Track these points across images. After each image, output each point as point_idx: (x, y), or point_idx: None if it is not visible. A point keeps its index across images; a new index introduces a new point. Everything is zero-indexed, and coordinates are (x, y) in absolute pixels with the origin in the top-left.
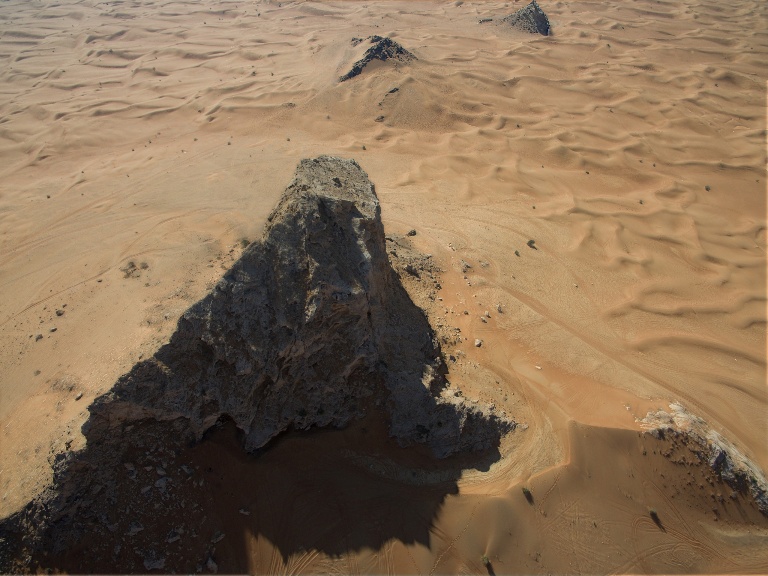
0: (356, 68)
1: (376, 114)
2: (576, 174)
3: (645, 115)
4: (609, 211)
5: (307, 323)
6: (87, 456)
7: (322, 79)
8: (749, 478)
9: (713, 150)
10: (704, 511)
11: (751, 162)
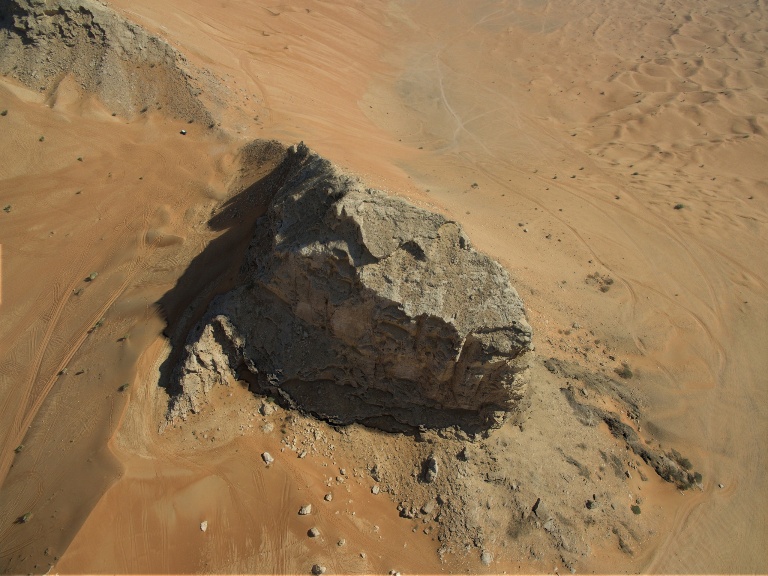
0: None
1: None
2: None
3: None
4: None
5: None
6: None
7: None
8: None
9: None
10: None
11: None
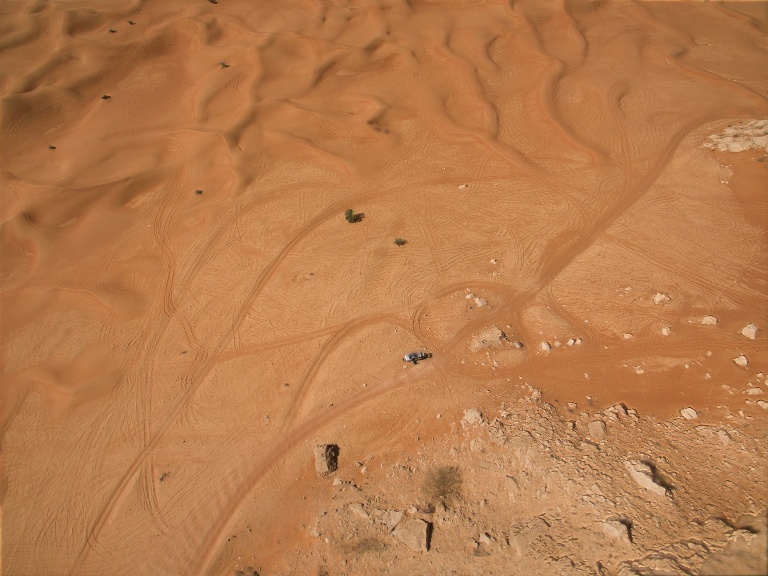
0: None
1: None
2: (103, 112)
3: None
4: (244, 102)
5: None
6: None
7: None
8: None
9: None
10: None
11: None
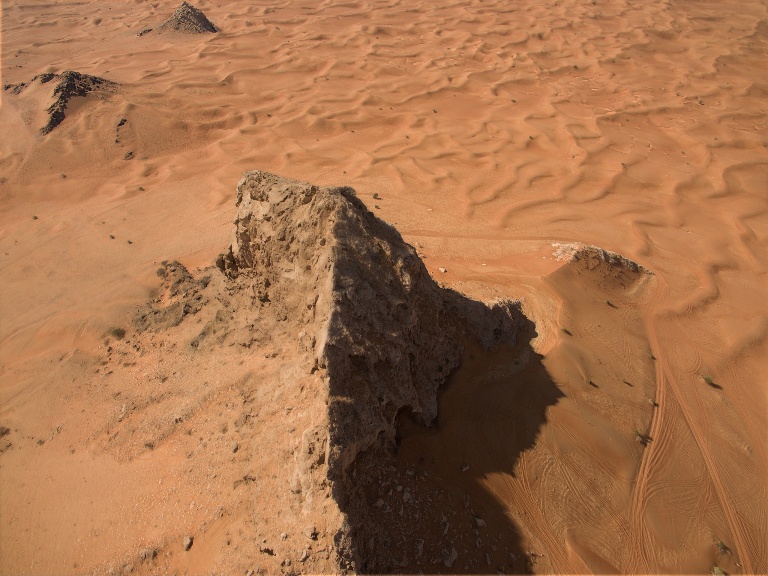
0: (55, 114)
1: (120, 153)
2: (347, 136)
3: (352, 75)
4: (396, 152)
5: (409, 293)
6: (350, 521)
7: (16, 139)
8: (619, 257)
9: (416, 84)
10: (618, 287)
11: (442, 85)
